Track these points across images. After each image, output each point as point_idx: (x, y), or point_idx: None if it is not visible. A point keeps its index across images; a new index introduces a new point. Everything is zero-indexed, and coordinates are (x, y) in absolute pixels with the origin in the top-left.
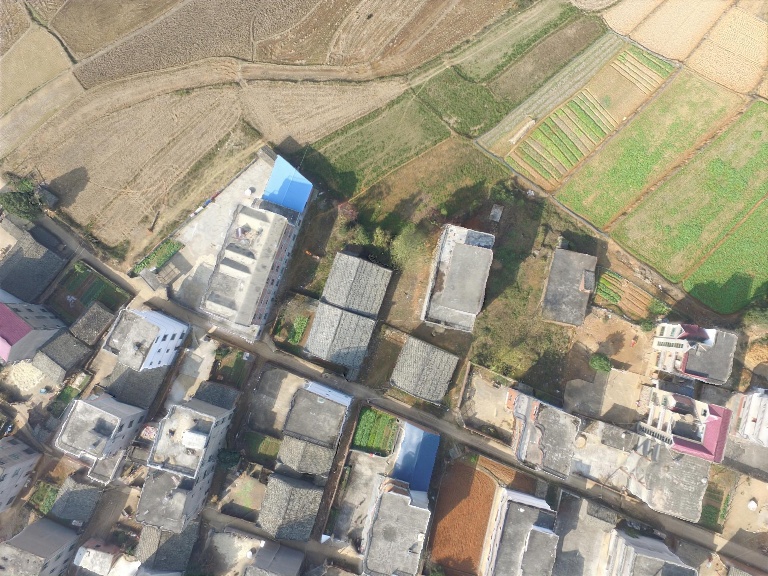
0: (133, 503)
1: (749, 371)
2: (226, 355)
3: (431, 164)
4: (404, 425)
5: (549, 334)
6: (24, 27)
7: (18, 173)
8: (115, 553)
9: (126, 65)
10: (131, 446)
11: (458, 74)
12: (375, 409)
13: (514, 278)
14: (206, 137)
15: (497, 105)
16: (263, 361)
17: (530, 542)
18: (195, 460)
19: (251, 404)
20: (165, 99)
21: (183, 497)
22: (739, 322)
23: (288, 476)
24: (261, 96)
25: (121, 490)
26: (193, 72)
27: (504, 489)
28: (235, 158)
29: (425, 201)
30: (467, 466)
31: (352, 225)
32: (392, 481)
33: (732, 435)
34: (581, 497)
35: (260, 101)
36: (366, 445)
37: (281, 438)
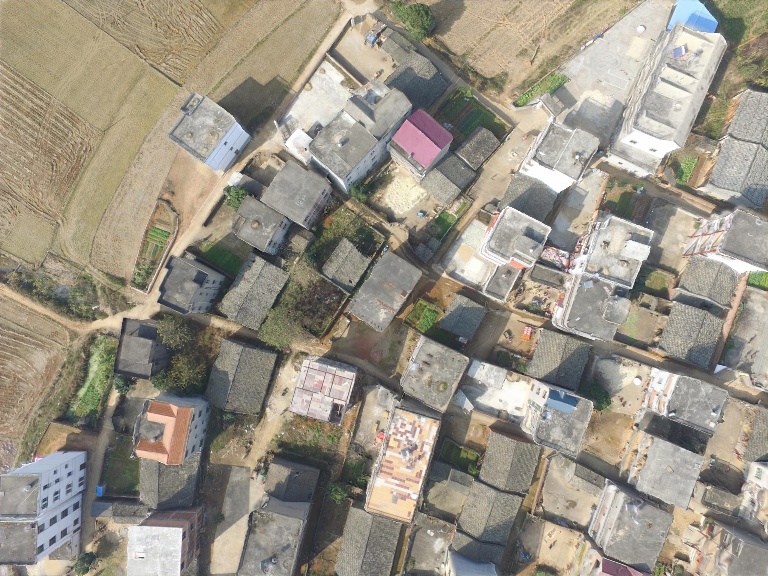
0: (513, 327)
1: None
2: (611, 190)
3: None
4: None
5: None
6: None
7: None
8: (506, 369)
9: None
10: None
11: None
12: None
13: None
14: None
15: None
16: (647, 199)
17: None
18: (628, 272)
19: None
20: None
21: (628, 303)
22: None
23: None
24: None
25: (501, 314)
26: None
27: None
28: None
29: None
30: None
31: (760, 65)
32: None
33: None
34: None
35: None
36: (758, 284)
37: (673, 272)
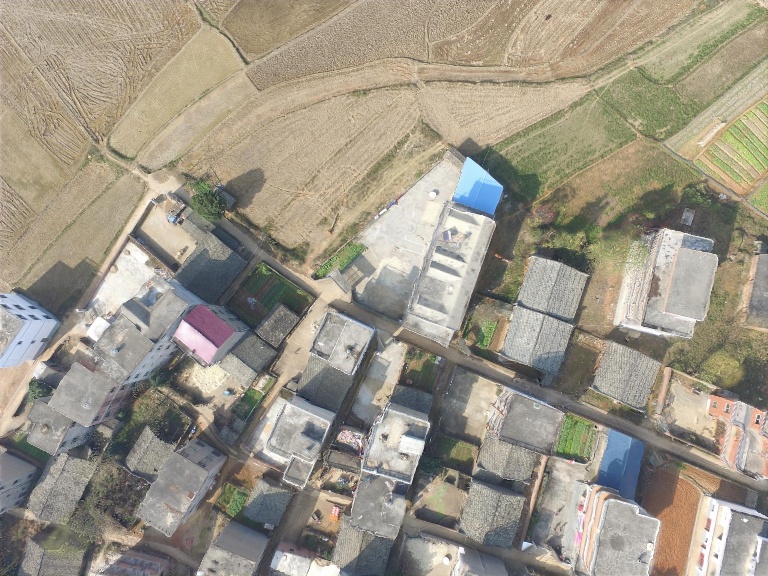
0: (322, 507)
1: None
2: (413, 359)
3: (617, 167)
4: (607, 432)
5: (749, 340)
6: (194, 28)
7: (193, 174)
8: (311, 557)
9: (299, 66)
10: (328, 450)
11: (643, 75)
12: (571, 415)
13: None
14: (384, 139)
15: (684, 107)
16: (451, 365)
17: (762, 553)
18: (409, 465)
19: (442, 408)
20: (341, 100)
21: (404, 503)
22: None
23: (488, 482)
24: (440, 97)
25: (309, 494)
26: (368, 73)
27: (710, 498)
28: (415, 160)
29: (612, 204)
30: (670, 474)
31: (546, 228)
32: (605, 489)
33: None
34: None
35: (438, 102)
36: (563, 451)
37: (476, 443)
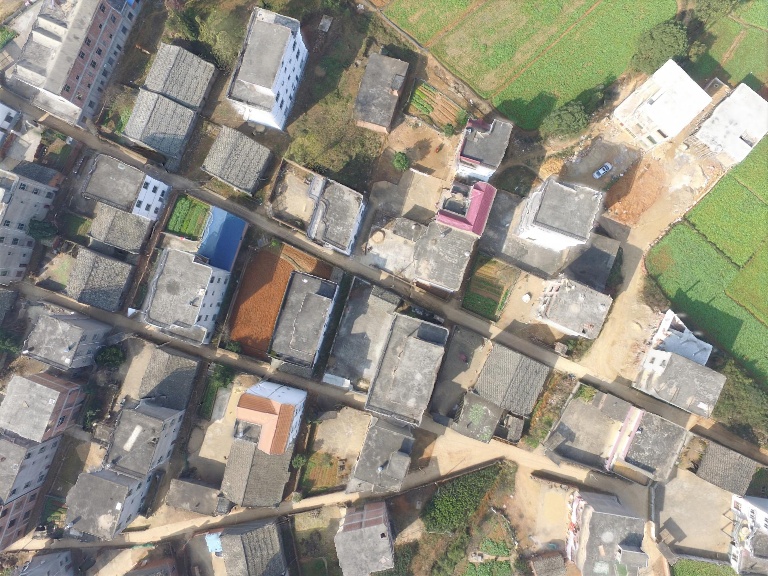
0: None
1: (541, 181)
2: (53, 142)
3: None
4: (212, 209)
5: (362, 138)
6: None
7: None
8: None
9: None
10: None
11: None
12: (191, 198)
13: (336, 86)
14: None
15: None
16: None
17: (305, 304)
18: None
19: (73, 188)
20: None
21: None
22: (537, 135)
23: (99, 251)
24: None
25: None
26: None
27: None
28: None
29: None
30: (272, 254)
31: None
32: None
33: (517, 236)
34: (373, 285)
35: None
36: (179, 231)
37: None
